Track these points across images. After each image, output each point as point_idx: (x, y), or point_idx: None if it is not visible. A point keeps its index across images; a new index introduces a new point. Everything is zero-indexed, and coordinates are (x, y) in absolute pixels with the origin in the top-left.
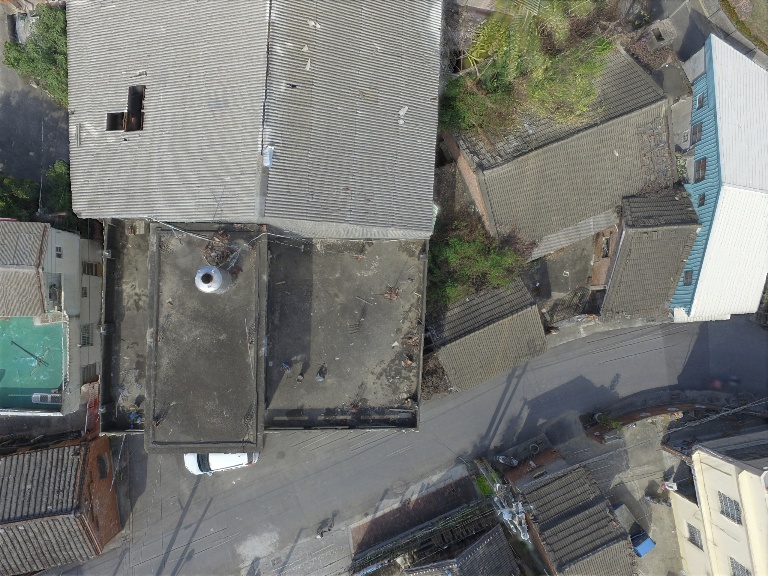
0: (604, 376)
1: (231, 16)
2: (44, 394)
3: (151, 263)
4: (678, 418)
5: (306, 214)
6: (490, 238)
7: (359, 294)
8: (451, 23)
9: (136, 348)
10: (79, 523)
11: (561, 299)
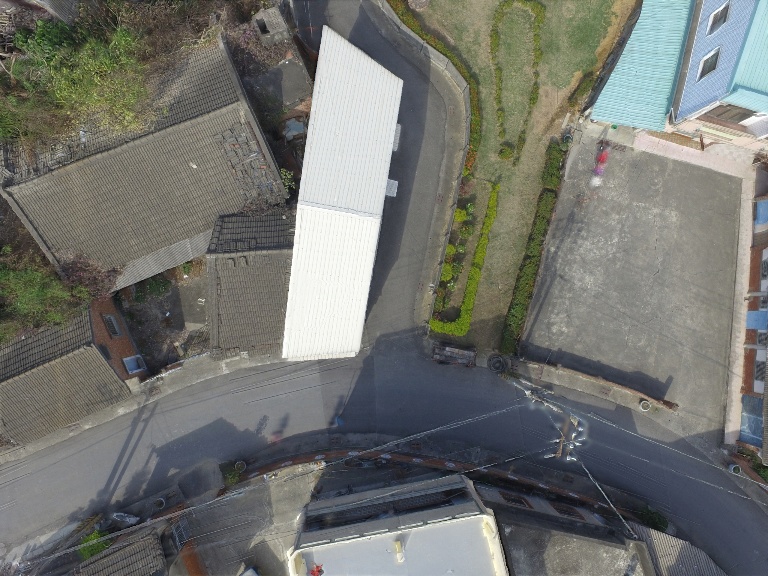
0: (249, 418)
1: None
2: None
3: None
4: None
5: None
6: (49, 265)
7: None
8: None
9: None
10: None
11: (198, 330)
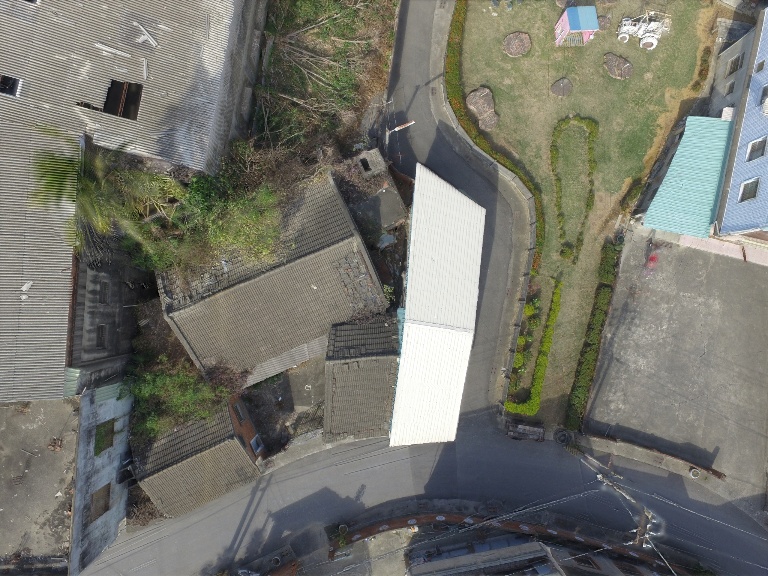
0: (349, 487)
1: None
2: None
3: None
4: (416, 531)
5: None
6: (196, 370)
7: (23, 446)
8: (135, 172)
9: None
10: None
11: (305, 412)
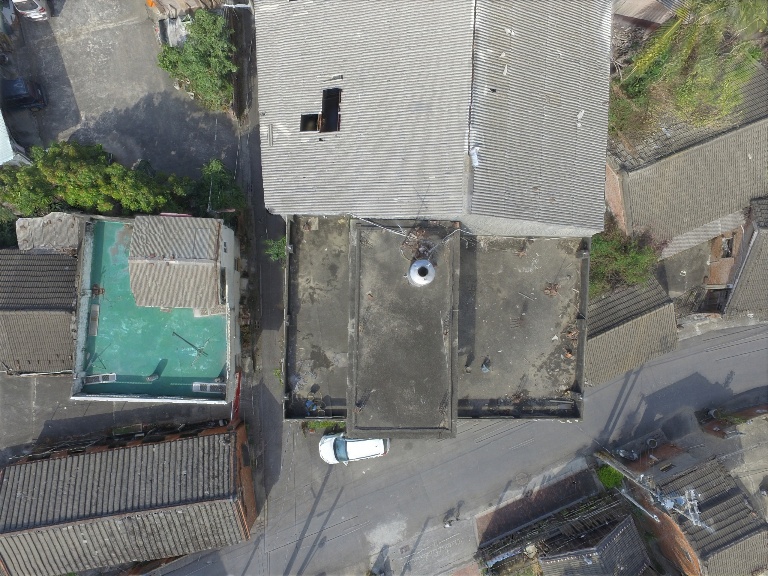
0: (719, 373)
1: (433, 24)
2: (204, 383)
3: (352, 257)
4: None
5: (504, 212)
6: (626, 237)
7: (520, 290)
8: None
9: (311, 339)
10: (235, 508)
11: (677, 298)
